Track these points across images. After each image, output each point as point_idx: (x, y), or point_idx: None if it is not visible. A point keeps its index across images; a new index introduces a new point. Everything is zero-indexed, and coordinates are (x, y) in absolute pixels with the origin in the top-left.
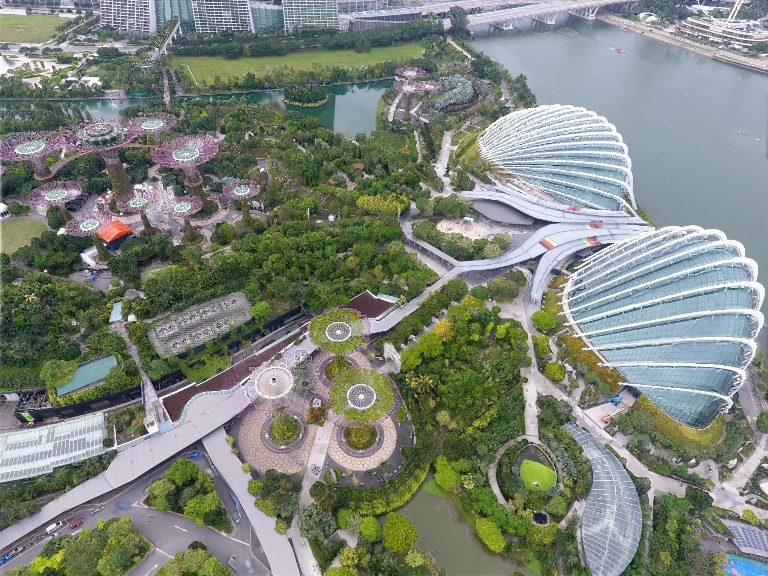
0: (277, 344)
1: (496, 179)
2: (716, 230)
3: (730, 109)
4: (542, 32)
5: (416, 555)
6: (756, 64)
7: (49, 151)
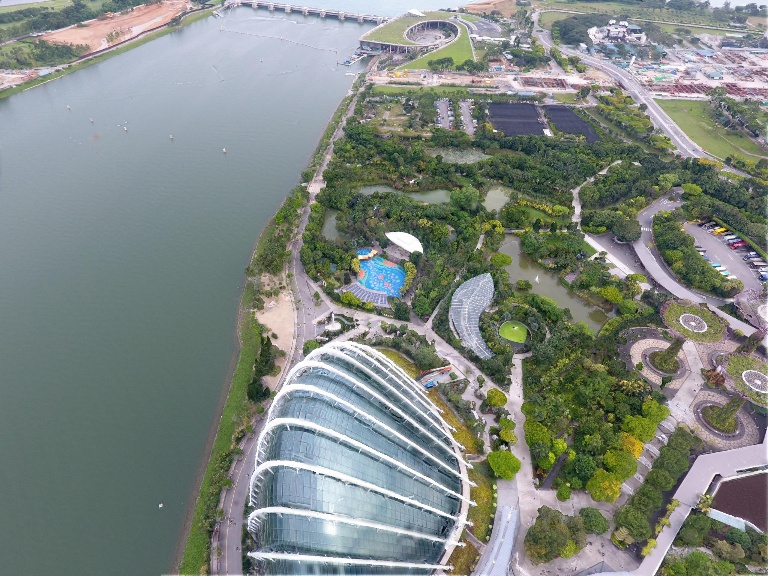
0: None
1: None
2: (283, 461)
3: None
4: None
5: (595, 291)
6: None
7: None
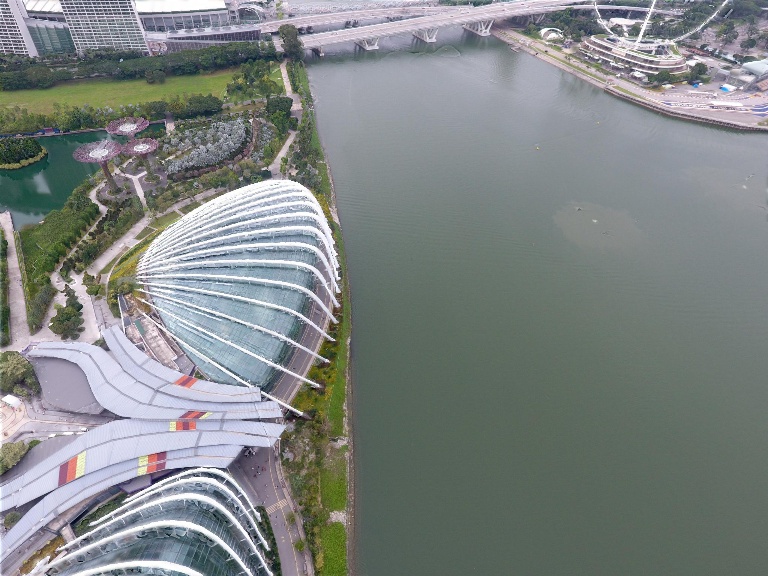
0: None
1: (126, 311)
2: (165, 562)
3: (584, 169)
4: (421, 51)
5: None
6: (652, 100)
7: None
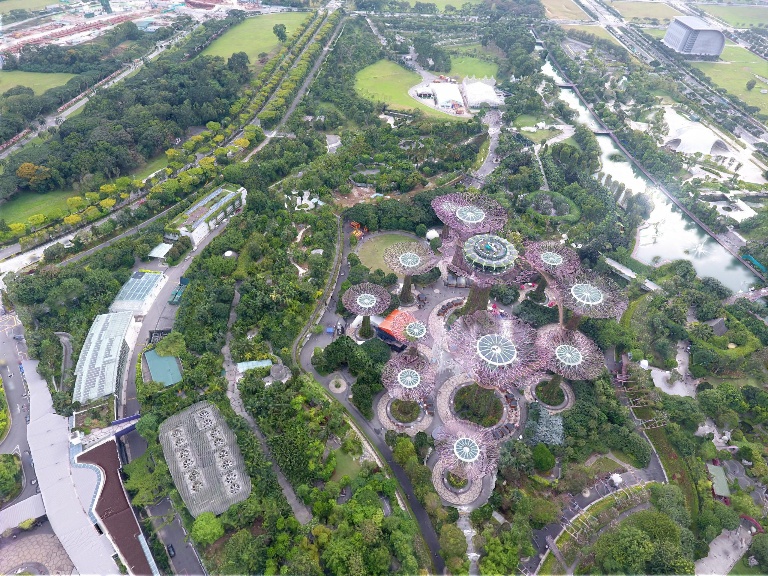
0: (149, 565)
1: None
2: None
3: None
4: None
5: None
6: None
7: None
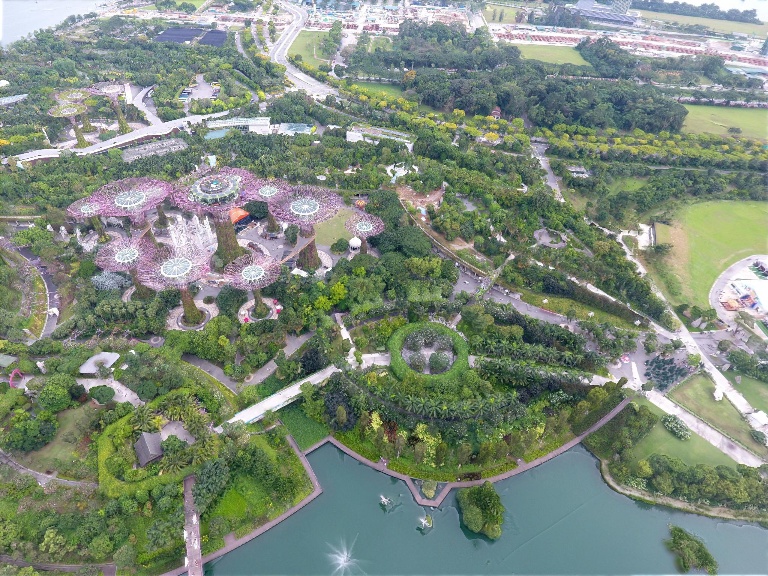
0: None
1: None
2: None
3: None
4: None
5: None
6: None
7: (279, 199)
